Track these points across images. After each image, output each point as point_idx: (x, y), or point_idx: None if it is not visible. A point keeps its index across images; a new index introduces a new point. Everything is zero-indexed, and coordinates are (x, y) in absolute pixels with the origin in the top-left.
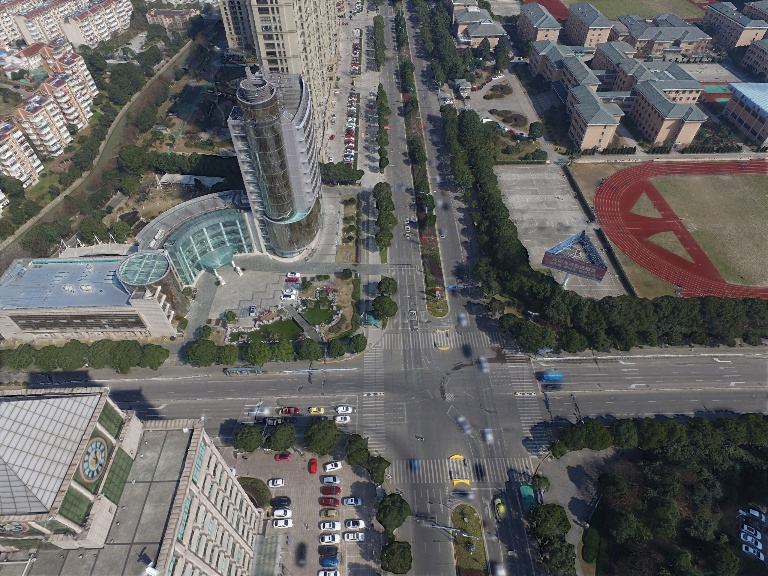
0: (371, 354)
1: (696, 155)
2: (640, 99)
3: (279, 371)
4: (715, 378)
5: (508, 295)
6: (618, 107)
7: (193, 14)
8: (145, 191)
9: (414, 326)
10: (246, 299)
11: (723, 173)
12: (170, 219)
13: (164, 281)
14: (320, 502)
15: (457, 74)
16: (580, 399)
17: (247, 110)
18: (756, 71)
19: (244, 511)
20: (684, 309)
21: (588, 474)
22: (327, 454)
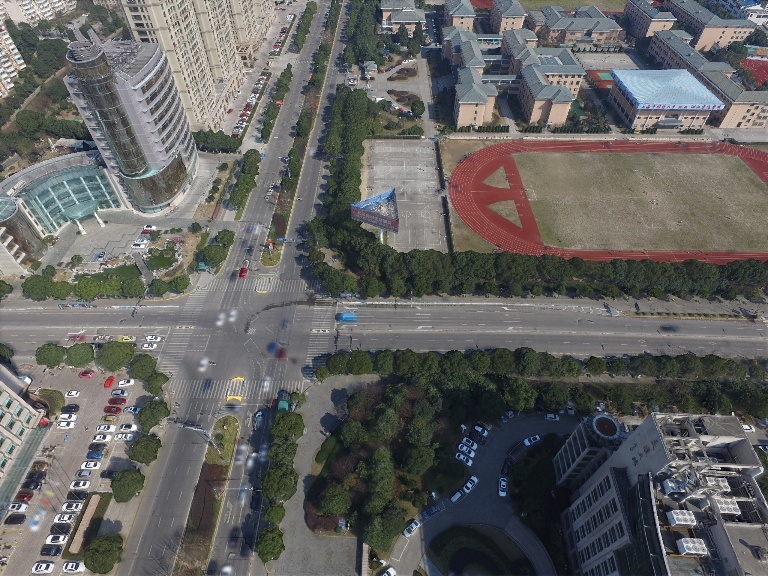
0: (196, 295)
1: (566, 135)
2: (523, 82)
3: (108, 306)
4: (497, 323)
5: (337, 249)
6: (494, 88)
7: None
8: (39, 153)
9: (243, 273)
10: (100, 247)
11: (584, 151)
12: (35, 173)
13: (10, 223)
14: (105, 410)
15: (366, 57)
16: (368, 336)
17: (77, 69)
18: (656, 61)
19: (3, 401)
20: (478, 261)
21: (349, 396)
22: (125, 373)
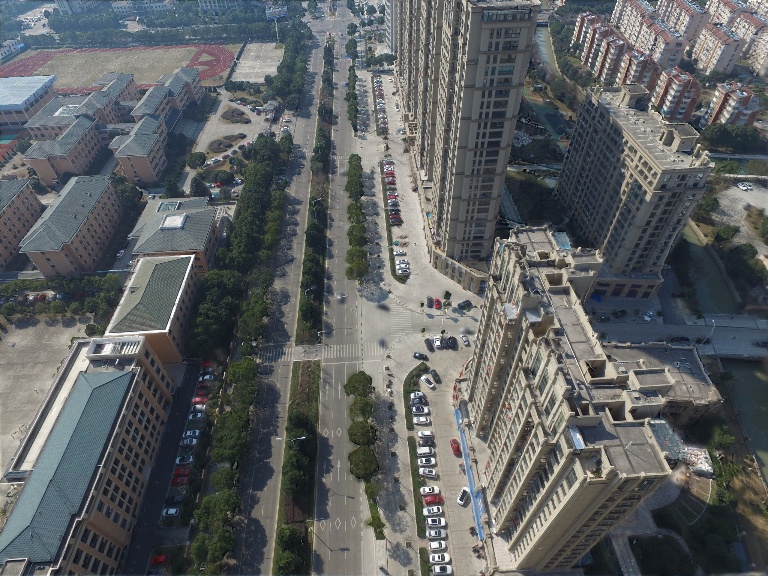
0: None
1: None
2: None
3: None
4: None
5: None
6: None
7: (767, 262)
8: None
9: None
10: None
11: None
12: None
13: None
14: None
15: None
16: None
17: None
18: None
19: None
20: None
21: None
22: None
